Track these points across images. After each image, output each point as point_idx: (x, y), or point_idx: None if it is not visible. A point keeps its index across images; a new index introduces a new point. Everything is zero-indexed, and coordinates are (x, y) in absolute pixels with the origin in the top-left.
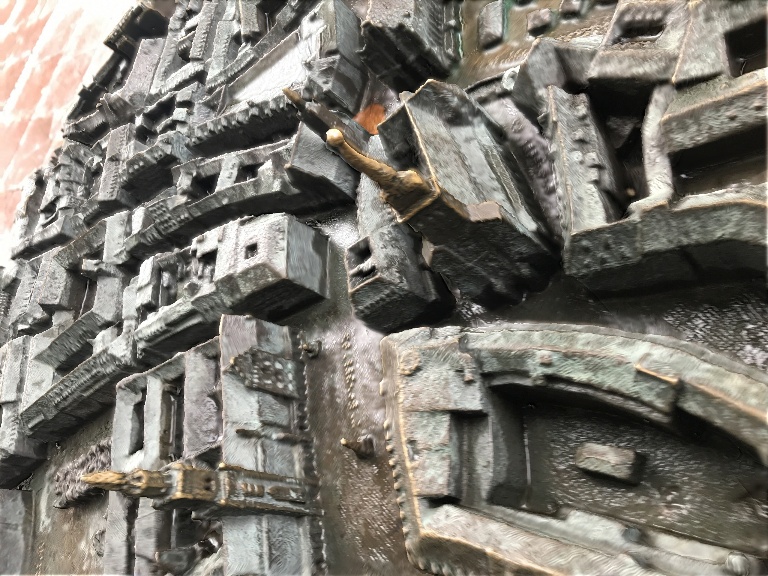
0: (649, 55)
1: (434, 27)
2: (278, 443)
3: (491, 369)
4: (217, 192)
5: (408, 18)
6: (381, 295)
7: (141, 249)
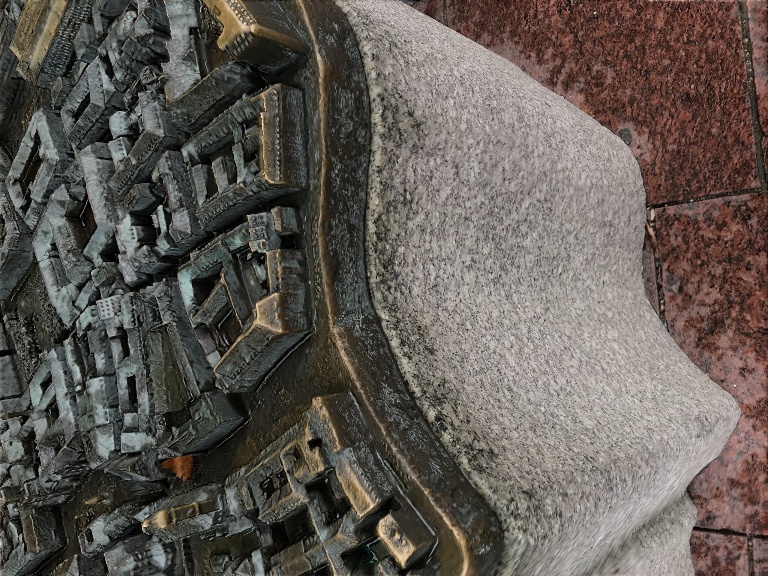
0: None
1: None
2: None
3: None
4: None
5: None
6: None
7: None
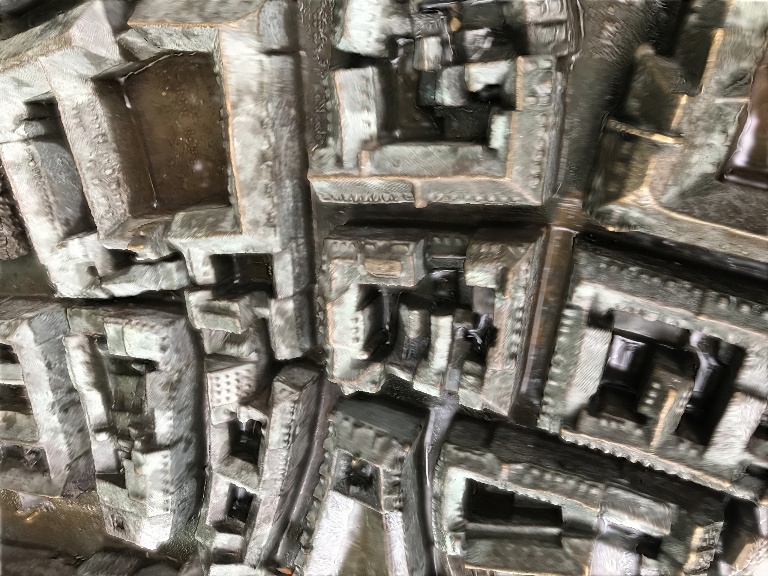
0: None
1: None
2: None
3: None
4: (212, 474)
5: None
6: None
7: None
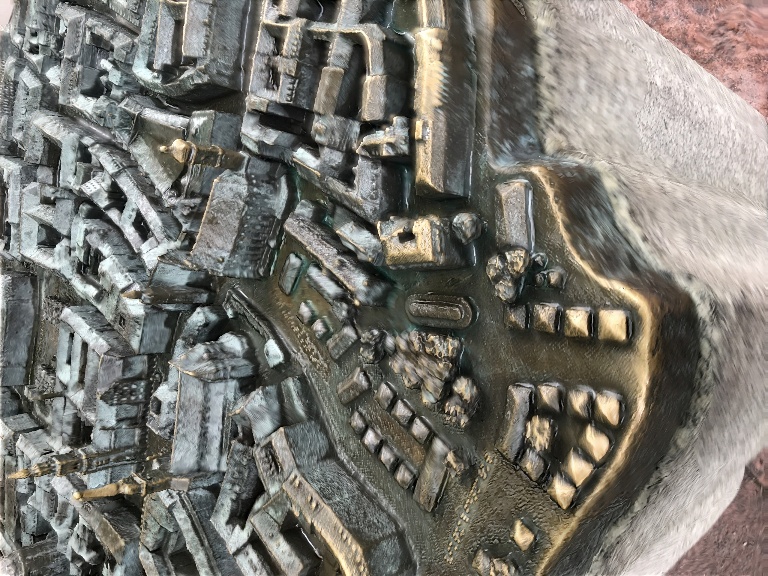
0: (265, 482)
1: (254, 248)
2: (126, 429)
3: None
4: (120, 228)
5: (221, 264)
6: None
7: None
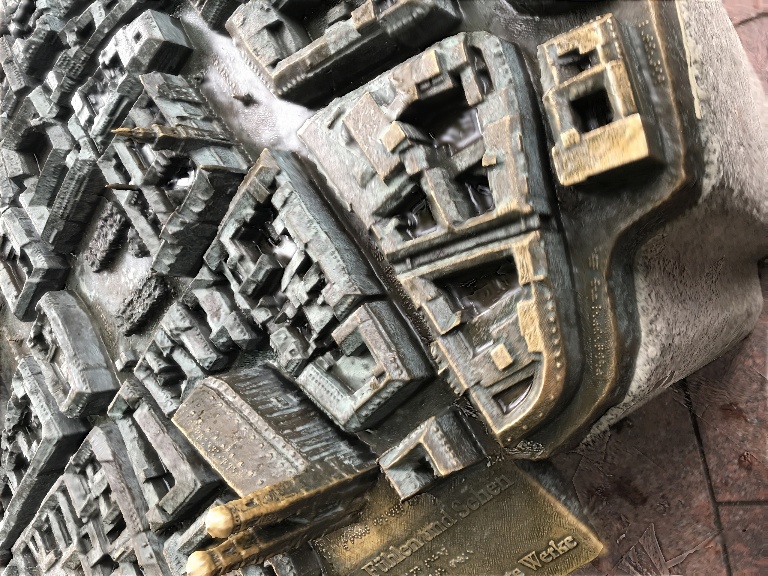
0: None
1: None
2: (202, 122)
3: (275, 0)
4: (98, 27)
5: None
6: (216, 7)
7: (65, 98)
